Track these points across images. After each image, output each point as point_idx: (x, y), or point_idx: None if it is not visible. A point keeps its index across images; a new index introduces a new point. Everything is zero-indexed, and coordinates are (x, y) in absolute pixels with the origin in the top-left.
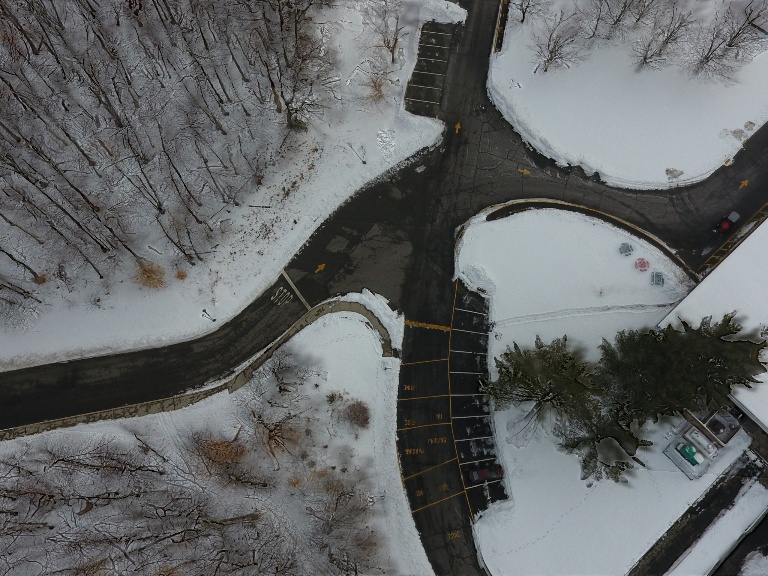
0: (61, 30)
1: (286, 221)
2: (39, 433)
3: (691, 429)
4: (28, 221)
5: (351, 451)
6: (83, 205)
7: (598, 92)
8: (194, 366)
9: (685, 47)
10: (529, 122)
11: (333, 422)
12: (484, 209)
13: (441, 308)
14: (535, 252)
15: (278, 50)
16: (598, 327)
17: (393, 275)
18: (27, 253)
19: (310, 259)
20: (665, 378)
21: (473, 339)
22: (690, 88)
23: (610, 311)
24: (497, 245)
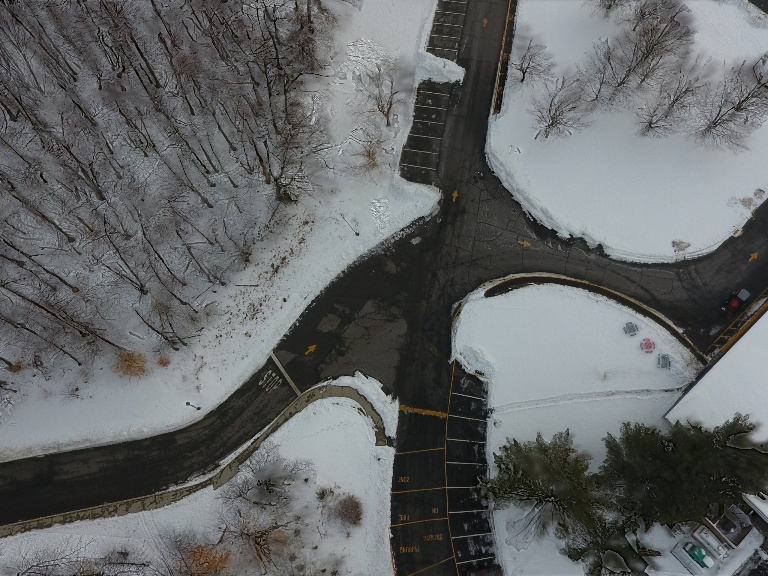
0: (40, 95)
1: (275, 299)
2: (13, 535)
3: (700, 528)
4: (3, 304)
5: (342, 551)
6: (61, 286)
7: (601, 157)
8: (177, 459)
9: (692, 112)
10: (529, 190)
11: (323, 520)
12: (482, 284)
13: (437, 392)
14: (536, 332)
15: (267, 116)
16: (602, 414)
17: (387, 356)
18: (2, 338)
19: (300, 340)
20: (675, 495)
21: (471, 426)
22: (697, 154)
23: (614, 396)
24: (496, 324)
